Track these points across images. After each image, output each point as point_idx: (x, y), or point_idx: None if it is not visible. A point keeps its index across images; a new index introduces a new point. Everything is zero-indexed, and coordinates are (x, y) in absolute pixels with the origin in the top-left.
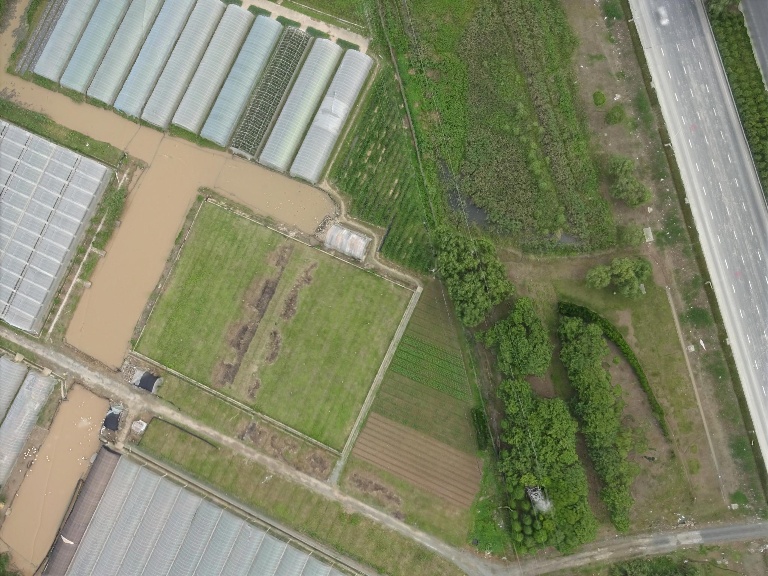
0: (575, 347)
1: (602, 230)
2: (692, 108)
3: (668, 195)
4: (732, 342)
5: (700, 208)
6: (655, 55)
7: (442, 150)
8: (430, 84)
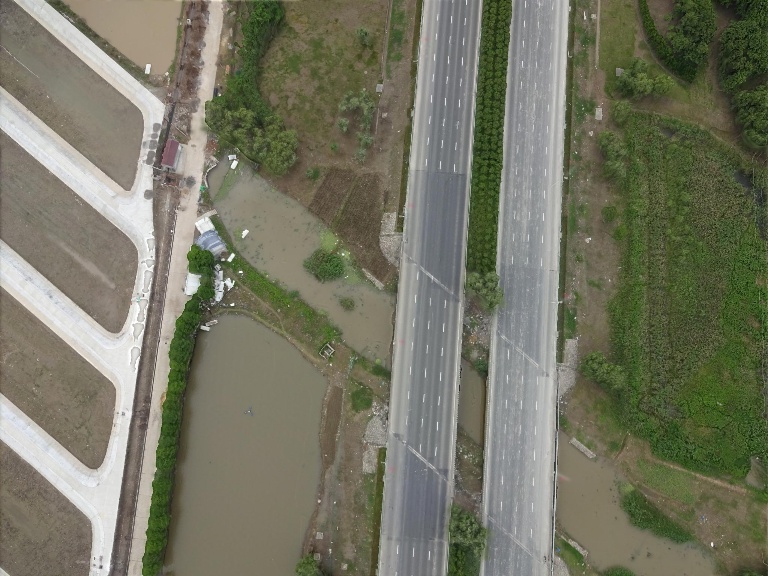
0: (707, 31)
1: (638, 129)
2: (534, 203)
3: (576, 138)
4: (567, 8)
5: (556, 117)
6: (549, 262)
7: (763, 245)
8: (760, 313)
